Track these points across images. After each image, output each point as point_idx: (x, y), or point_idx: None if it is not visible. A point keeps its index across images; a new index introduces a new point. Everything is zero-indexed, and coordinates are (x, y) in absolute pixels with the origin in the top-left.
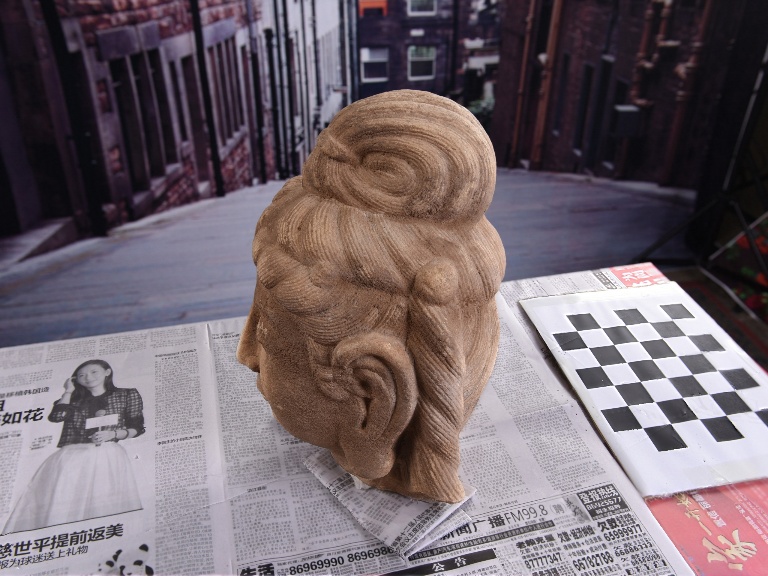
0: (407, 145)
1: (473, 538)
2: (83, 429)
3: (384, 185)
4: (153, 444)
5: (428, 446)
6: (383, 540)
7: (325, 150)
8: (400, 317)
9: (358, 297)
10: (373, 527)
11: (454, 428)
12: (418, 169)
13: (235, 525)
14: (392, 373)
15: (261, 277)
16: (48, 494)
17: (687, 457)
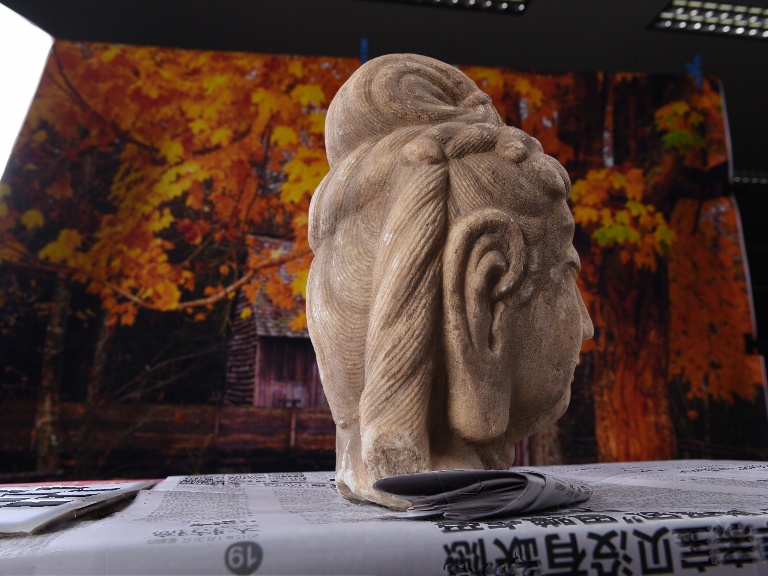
0: None
1: None
2: None
3: None
4: None
5: None
6: None
7: None
8: None
9: None
10: None
11: None
12: None
13: None
14: None
15: None
16: None
17: None
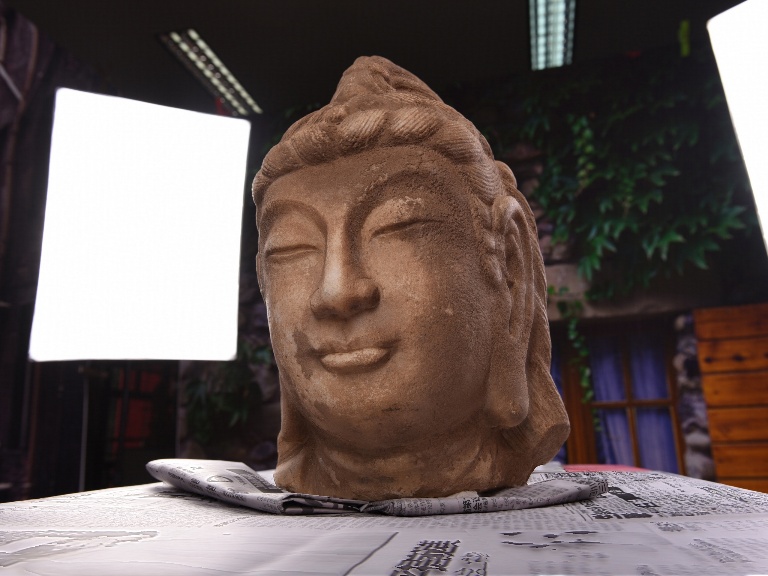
0: None
1: None
2: (3, 553)
3: None
4: (211, 527)
5: (541, 356)
6: (578, 487)
7: (377, 68)
8: None
9: None
10: (550, 495)
11: None
12: None
13: None
14: (522, 246)
15: (418, 123)
16: (202, 570)
17: None
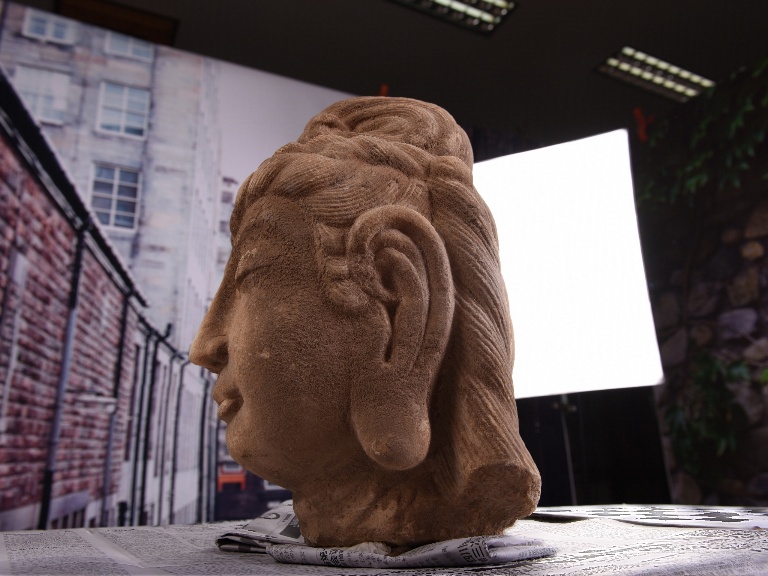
0: (396, 105)
1: (574, 556)
2: None
3: (379, 130)
4: None
5: (477, 378)
6: (442, 548)
7: (317, 119)
8: (422, 194)
9: (375, 170)
10: None
11: (504, 348)
12: (409, 117)
13: (171, 571)
14: (422, 254)
15: (259, 177)
16: None
17: (763, 521)
